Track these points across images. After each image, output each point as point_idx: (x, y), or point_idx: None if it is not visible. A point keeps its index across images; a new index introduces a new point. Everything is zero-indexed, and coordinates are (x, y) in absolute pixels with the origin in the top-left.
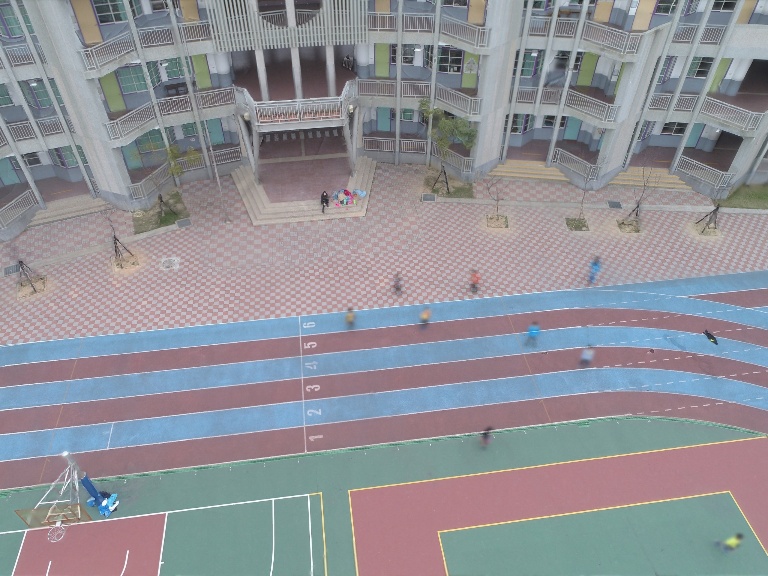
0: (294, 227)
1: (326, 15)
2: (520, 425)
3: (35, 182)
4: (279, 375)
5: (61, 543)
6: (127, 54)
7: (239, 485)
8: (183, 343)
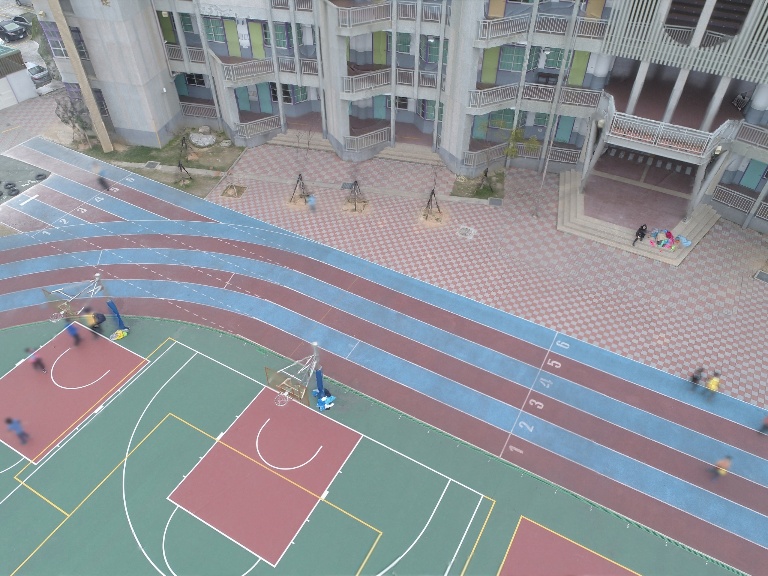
0: (596, 247)
1: (739, 43)
2: (747, 571)
3: (396, 123)
4: (511, 375)
5: (282, 410)
6: (518, 34)
7: (429, 449)
8: (443, 305)
